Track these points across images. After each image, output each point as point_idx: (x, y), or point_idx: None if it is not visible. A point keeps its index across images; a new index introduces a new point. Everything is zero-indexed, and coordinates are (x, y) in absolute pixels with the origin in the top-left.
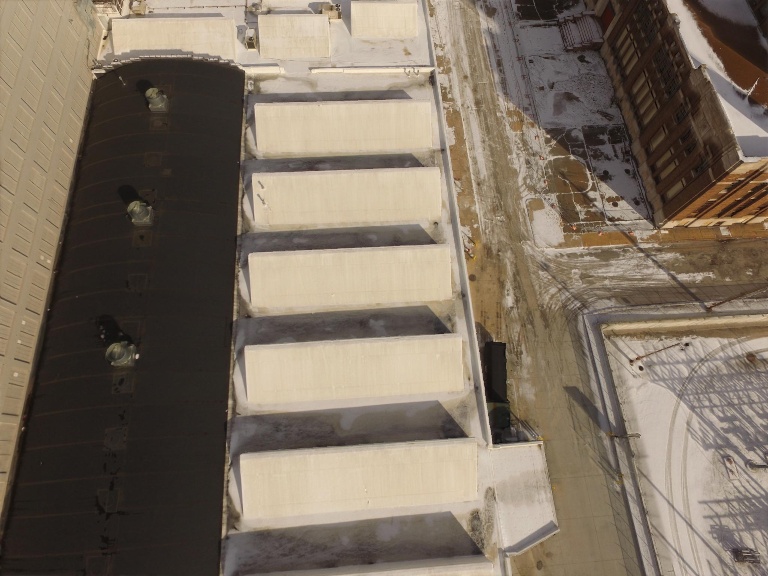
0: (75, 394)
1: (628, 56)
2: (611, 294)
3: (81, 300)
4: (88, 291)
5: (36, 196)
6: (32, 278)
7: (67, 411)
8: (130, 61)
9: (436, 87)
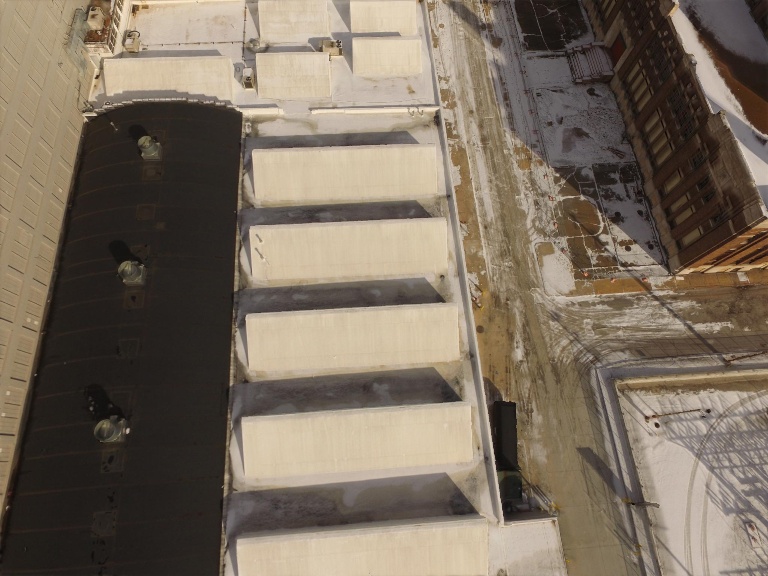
0: (62, 473)
1: (640, 92)
2: (625, 346)
3: (69, 367)
4: (77, 357)
5: (22, 256)
6: (17, 344)
7: (53, 492)
8: (122, 104)
9: (441, 128)
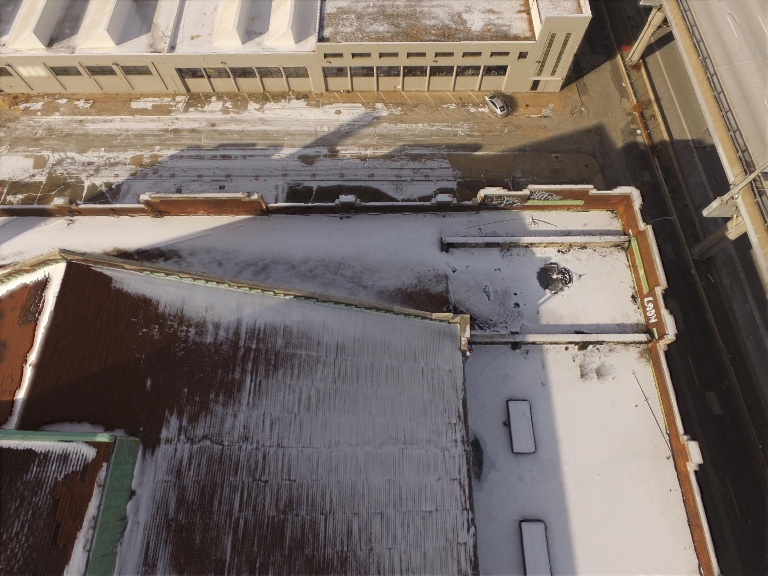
0: None
1: None
2: None
3: None
4: None
5: None
6: None
7: None
8: None
9: None
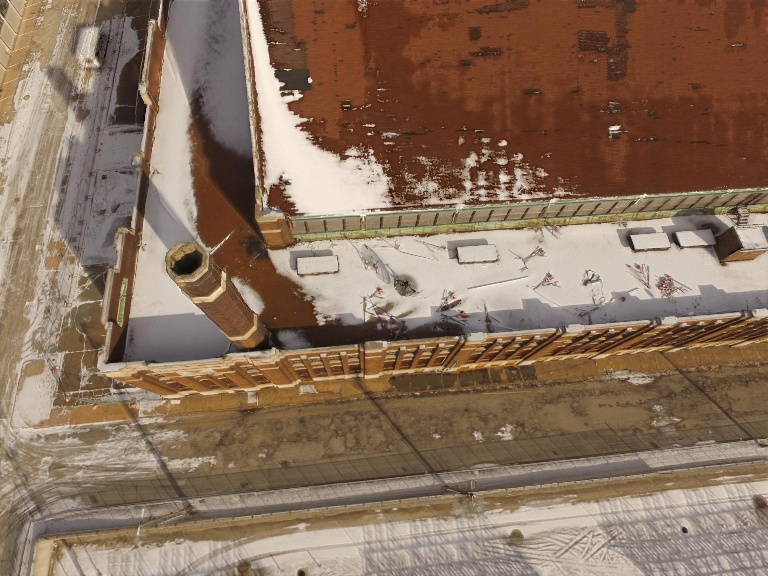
0: None
1: None
2: (78, 491)
3: None
4: None
5: None
6: None
7: None
8: None
9: None
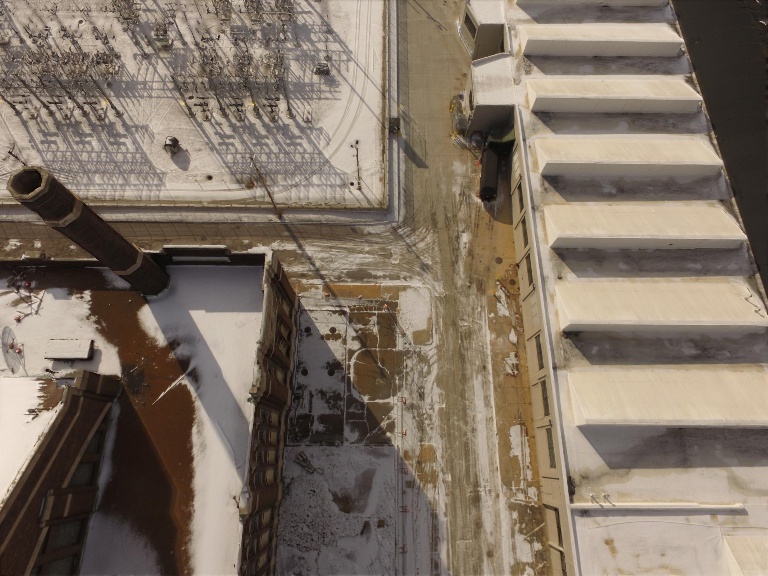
0: None
1: None
2: (366, 237)
3: None
4: None
5: None
6: None
7: None
8: None
9: None
